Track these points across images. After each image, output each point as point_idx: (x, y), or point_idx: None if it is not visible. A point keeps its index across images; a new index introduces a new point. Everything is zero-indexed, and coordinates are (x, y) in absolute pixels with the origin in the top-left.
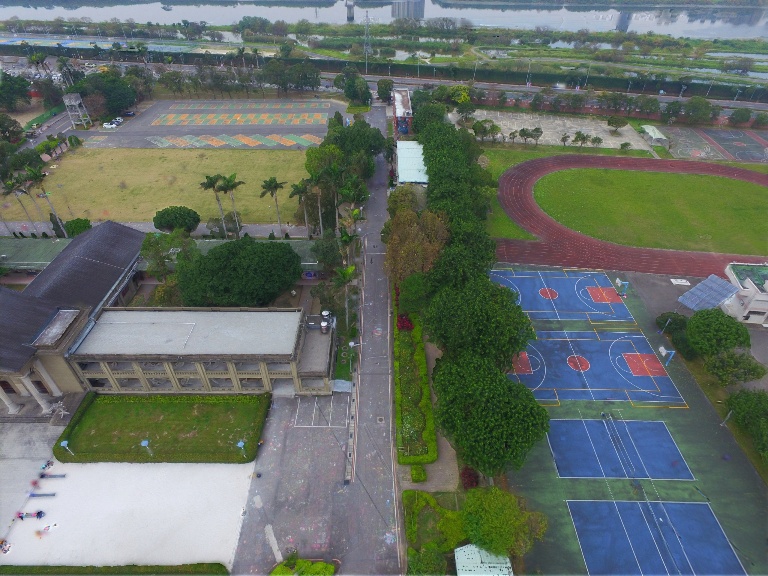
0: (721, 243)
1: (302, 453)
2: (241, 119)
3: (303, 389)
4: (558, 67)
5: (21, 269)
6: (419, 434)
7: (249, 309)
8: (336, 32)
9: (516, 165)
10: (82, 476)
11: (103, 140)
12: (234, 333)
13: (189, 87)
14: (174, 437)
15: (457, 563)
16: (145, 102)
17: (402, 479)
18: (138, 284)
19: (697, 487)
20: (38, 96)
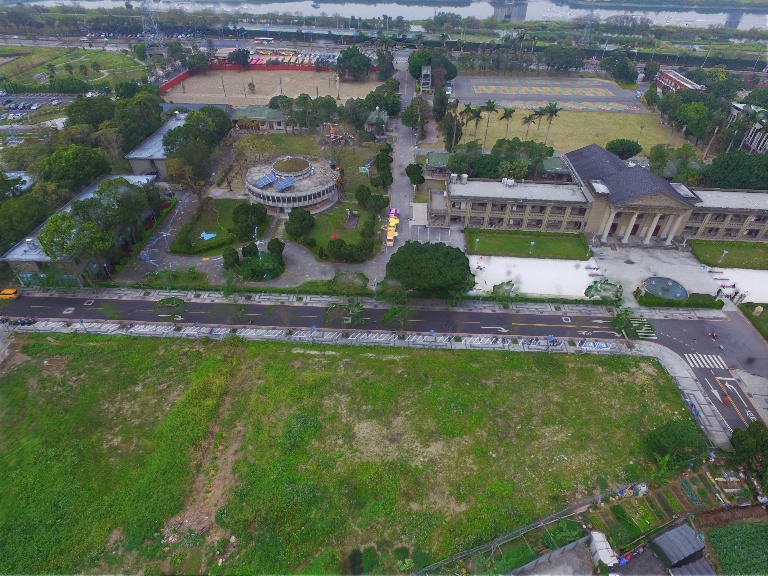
0: None
1: None
2: (543, 91)
3: None
4: None
5: None
6: None
7: None
8: (522, 27)
9: None
10: None
11: None
12: None
13: None
14: (765, 260)
15: None
16: None
17: None
18: None
19: None
20: None
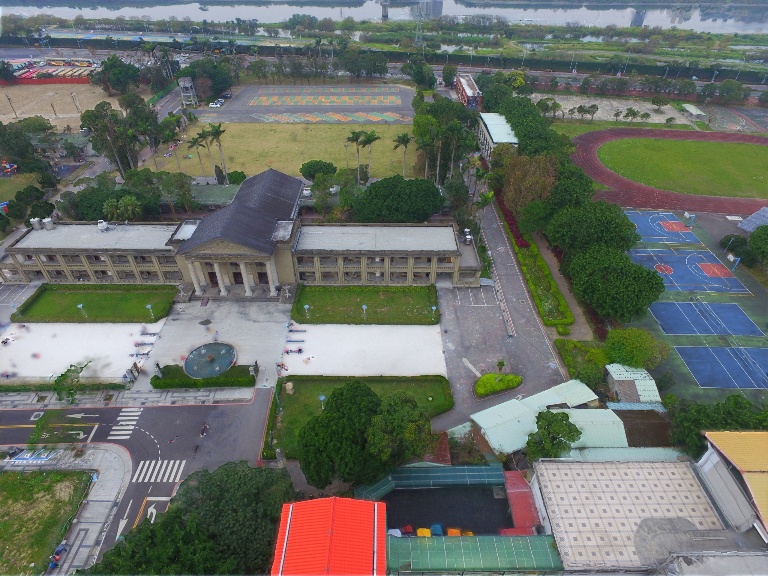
0: (764, 192)
1: (472, 320)
2: (326, 100)
3: (459, 282)
4: (594, 58)
5: (205, 206)
6: (556, 308)
7: (413, 224)
8: (380, 28)
9: (578, 136)
10: (317, 332)
11: (214, 117)
12: (408, 239)
13: (273, 74)
14: (373, 310)
15: (610, 371)
16: (235, 87)
17: (551, 334)
18: (299, 218)
19: (767, 340)
20: None
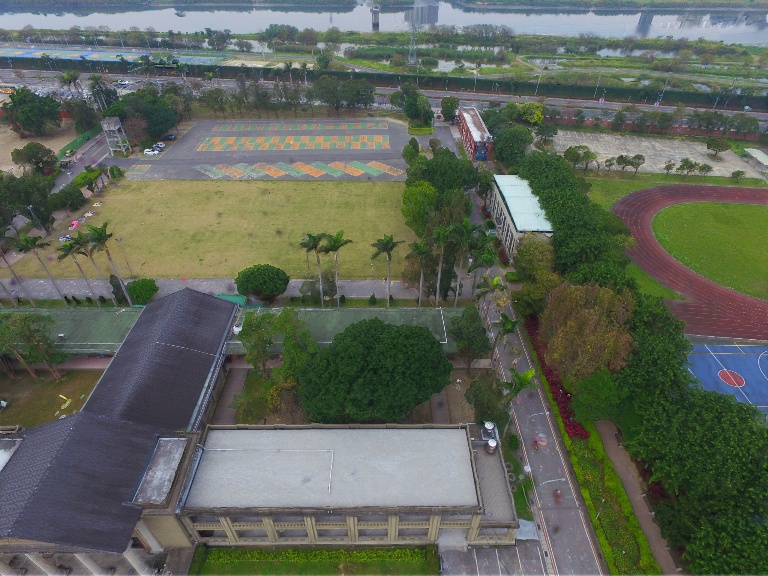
0: None
1: None
2: (295, 143)
3: (478, 538)
4: (619, 79)
5: None
6: None
7: (398, 426)
8: (368, 40)
9: (620, 199)
10: None
11: (147, 170)
12: (389, 466)
13: (232, 106)
14: None
15: None
16: (184, 123)
17: None
18: (226, 369)
19: None
20: (66, 116)
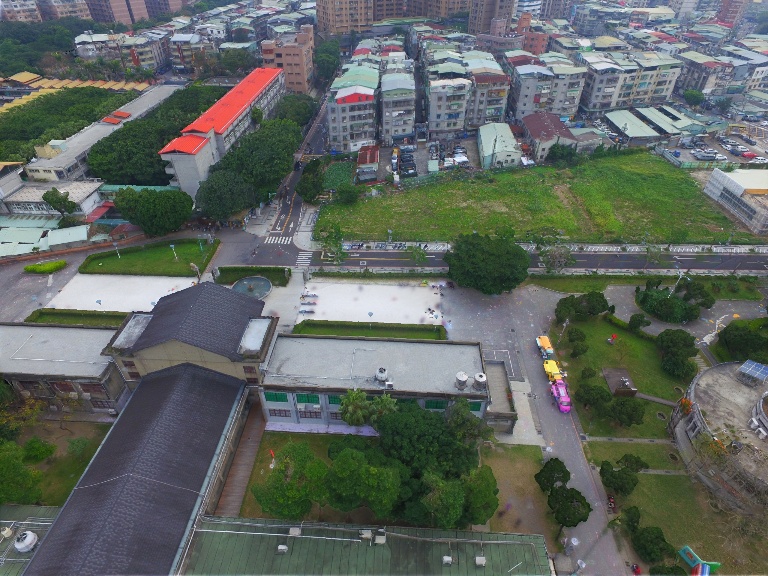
0: None
1: (3, 316)
2: None
3: None
4: None
5: None
6: None
7: None
8: None
9: None
10: None
11: None
12: None
13: None
14: None
15: None
16: None
17: None
18: None
19: None
20: None
